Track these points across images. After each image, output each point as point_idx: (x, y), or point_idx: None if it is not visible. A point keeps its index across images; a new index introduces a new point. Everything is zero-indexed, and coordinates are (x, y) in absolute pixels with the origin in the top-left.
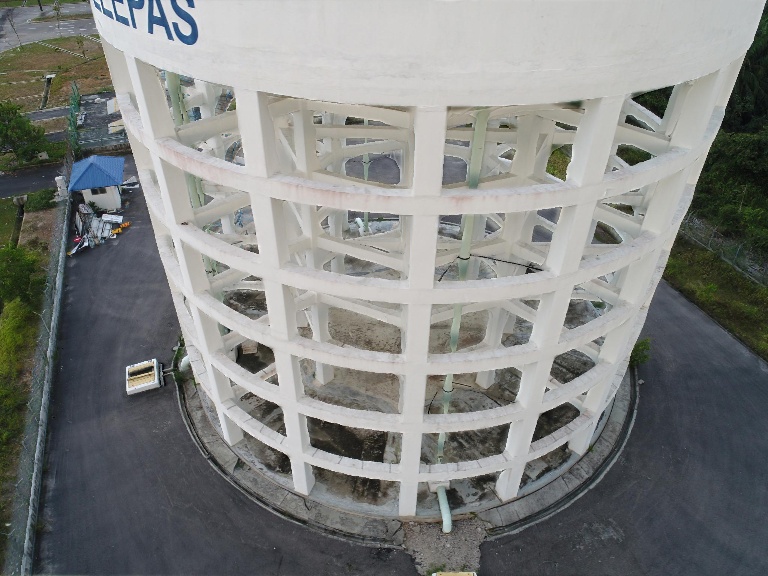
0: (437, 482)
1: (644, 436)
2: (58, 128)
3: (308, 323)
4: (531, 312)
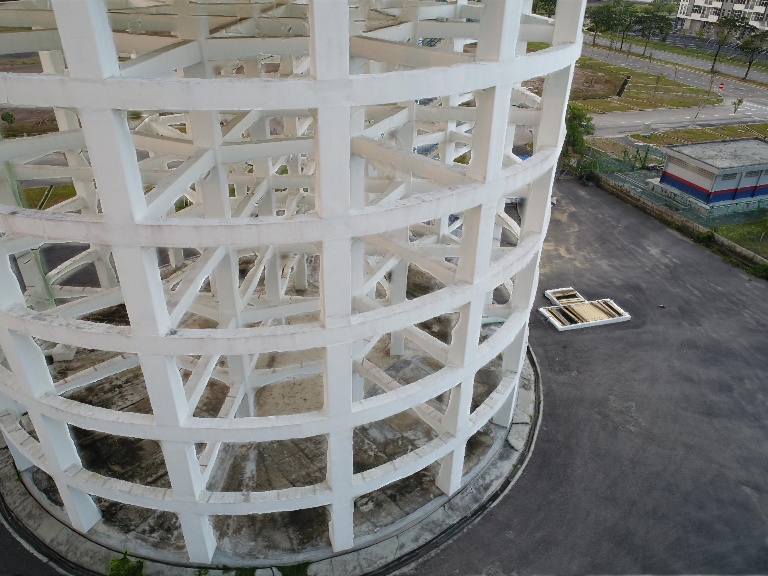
0: (57, 346)
1: (2, 555)
2: (640, 163)
3: (295, 285)
4: (90, 296)
